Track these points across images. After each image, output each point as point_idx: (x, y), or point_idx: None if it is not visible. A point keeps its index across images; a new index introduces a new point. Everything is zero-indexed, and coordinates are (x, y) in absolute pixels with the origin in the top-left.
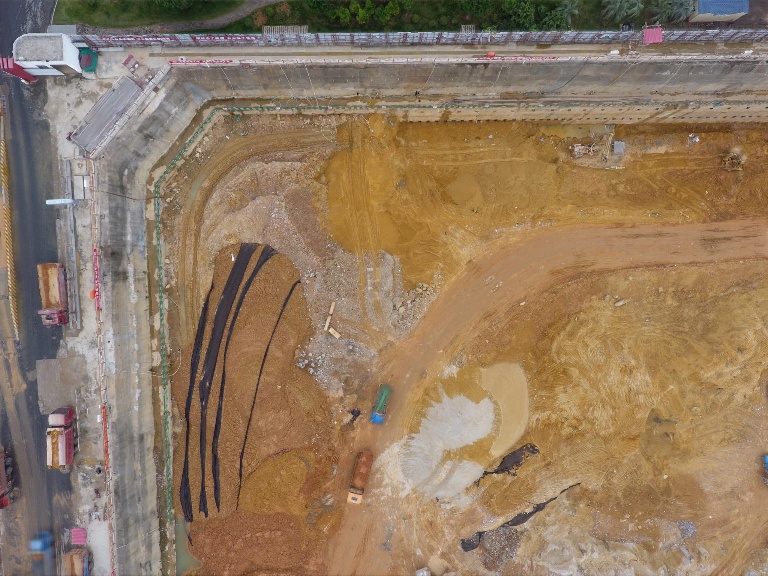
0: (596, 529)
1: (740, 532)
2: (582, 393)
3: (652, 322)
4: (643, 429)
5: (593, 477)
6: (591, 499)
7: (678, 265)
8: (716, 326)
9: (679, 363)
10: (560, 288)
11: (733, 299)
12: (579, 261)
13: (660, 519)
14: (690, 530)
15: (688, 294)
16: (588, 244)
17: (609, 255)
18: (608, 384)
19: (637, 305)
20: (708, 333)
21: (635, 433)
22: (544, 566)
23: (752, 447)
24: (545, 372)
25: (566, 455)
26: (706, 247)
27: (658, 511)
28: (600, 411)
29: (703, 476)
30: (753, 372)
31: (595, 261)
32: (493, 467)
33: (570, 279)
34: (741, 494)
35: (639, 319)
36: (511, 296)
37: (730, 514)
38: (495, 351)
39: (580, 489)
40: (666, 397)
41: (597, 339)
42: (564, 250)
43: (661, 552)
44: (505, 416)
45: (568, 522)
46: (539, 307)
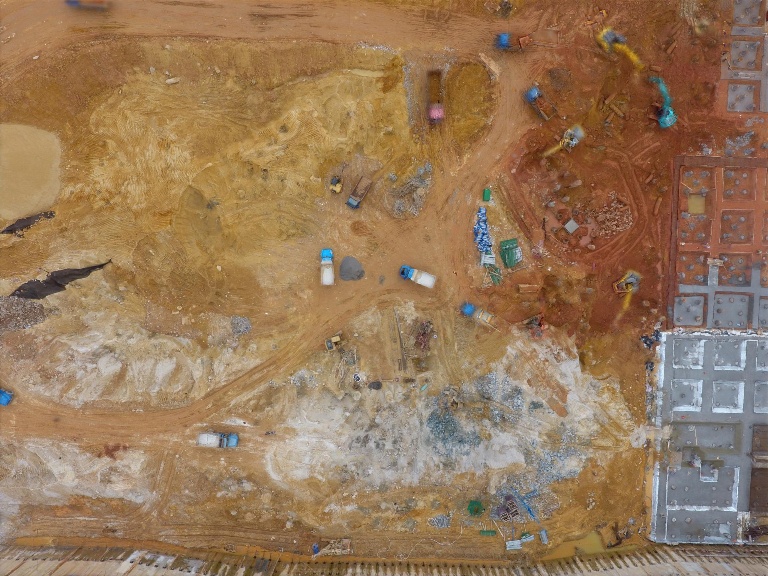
0: (147, 320)
1: (298, 331)
2: (118, 166)
3: (210, 105)
4: (175, 205)
5: (124, 254)
6: (136, 285)
7: (224, 39)
8: (280, 114)
9: (232, 147)
10: (82, 47)
11: (299, 87)
12: (107, 22)
13: (214, 313)
14: (241, 324)
15: (251, 79)
16: (118, 5)
17: (143, 20)
18: (145, 158)
19: (194, 86)
20: (270, 121)
21: (167, 209)
22: (66, 343)
23: (314, 243)
24: (81, 143)
25: (88, 225)
26: (256, 23)
27: (212, 305)
28: (134, 185)
29: (261, 270)
30: (300, 155)
31: (126, 24)
32: (2, 228)
33: (95, 39)
34: (299, 291)
35: (196, 101)
36: (24, 49)
37: (287, 312)
38: (5, 105)
39: (112, 267)
40: (212, 179)
41: (142, 114)
42: (89, 8)
43: (214, 348)
44: (3, 168)
45: (116, 310)
46: (58, 65)
